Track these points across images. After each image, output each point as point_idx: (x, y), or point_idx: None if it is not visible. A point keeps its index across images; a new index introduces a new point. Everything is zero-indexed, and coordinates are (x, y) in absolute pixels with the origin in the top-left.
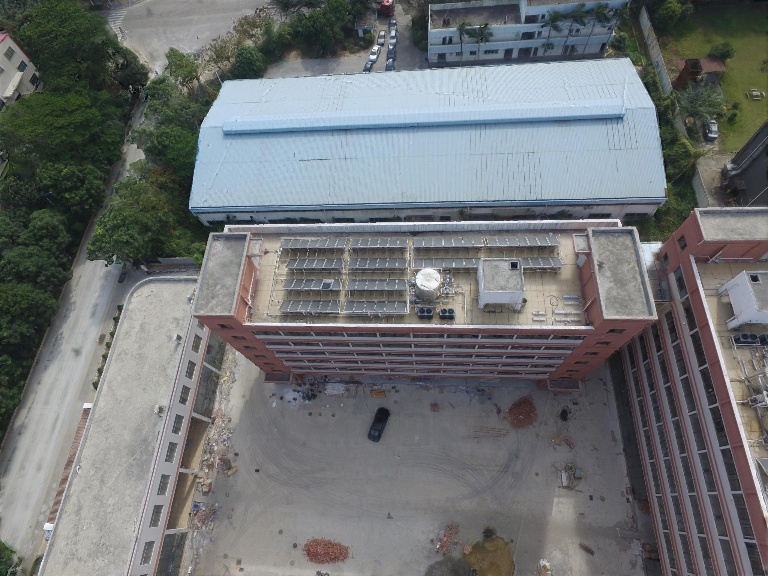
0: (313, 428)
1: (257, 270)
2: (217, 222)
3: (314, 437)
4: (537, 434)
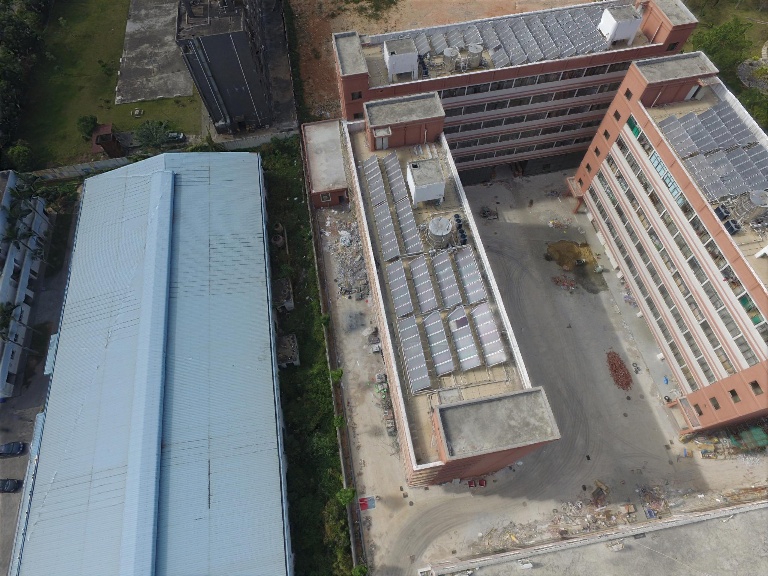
0: None
1: None
2: None
3: None
4: None
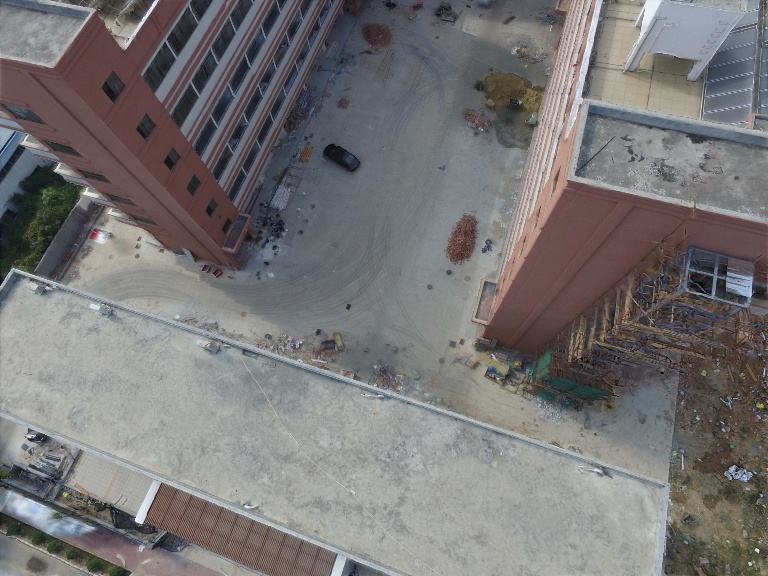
0: (319, 231)
1: None
2: None
3: (331, 232)
4: (401, 29)
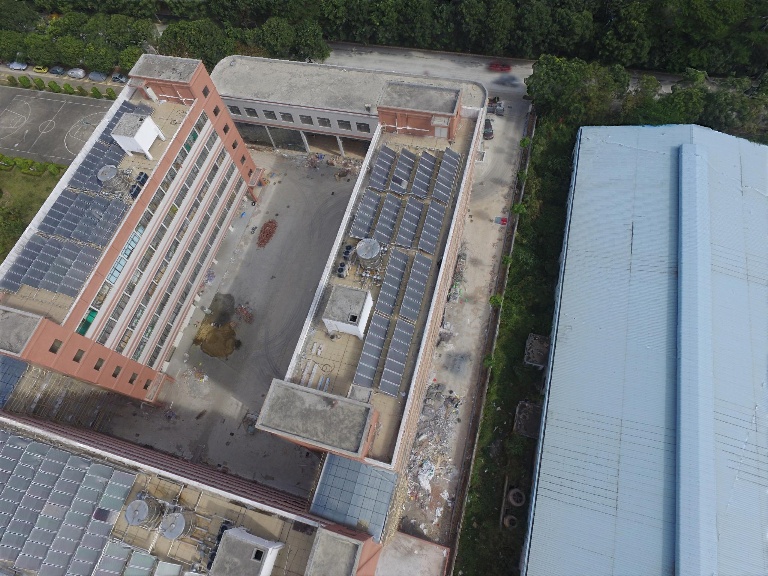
0: None
1: (434, 136)
2: (573, 159)
3: None
4: None
